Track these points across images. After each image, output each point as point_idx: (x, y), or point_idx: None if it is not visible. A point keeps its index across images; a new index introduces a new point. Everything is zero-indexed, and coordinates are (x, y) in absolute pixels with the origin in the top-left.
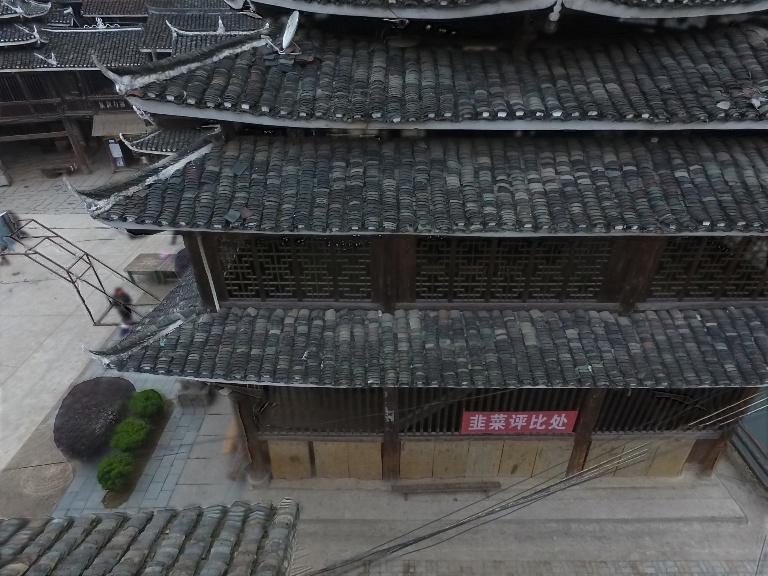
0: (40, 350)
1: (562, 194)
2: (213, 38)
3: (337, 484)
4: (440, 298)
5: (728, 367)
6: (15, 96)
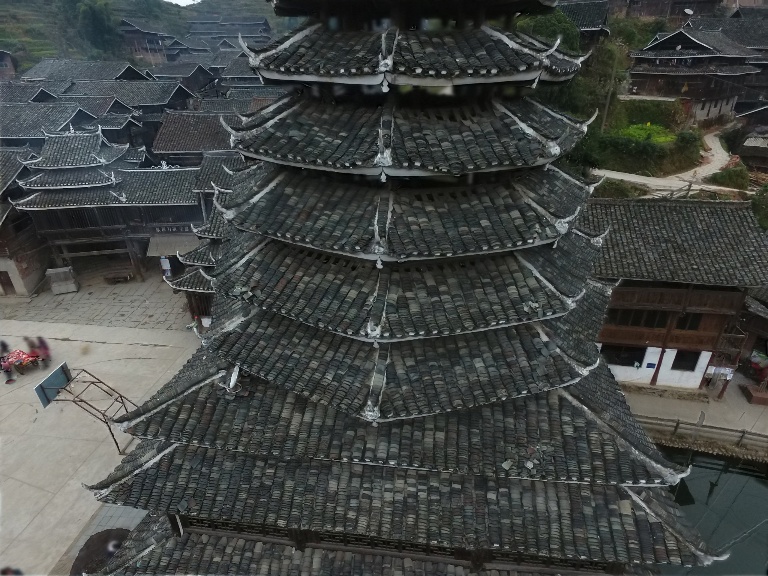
0: (74, 477)
1: (405, 504)
2: None
3: None
4: (338, 542)
5: None
6: (91, 223)
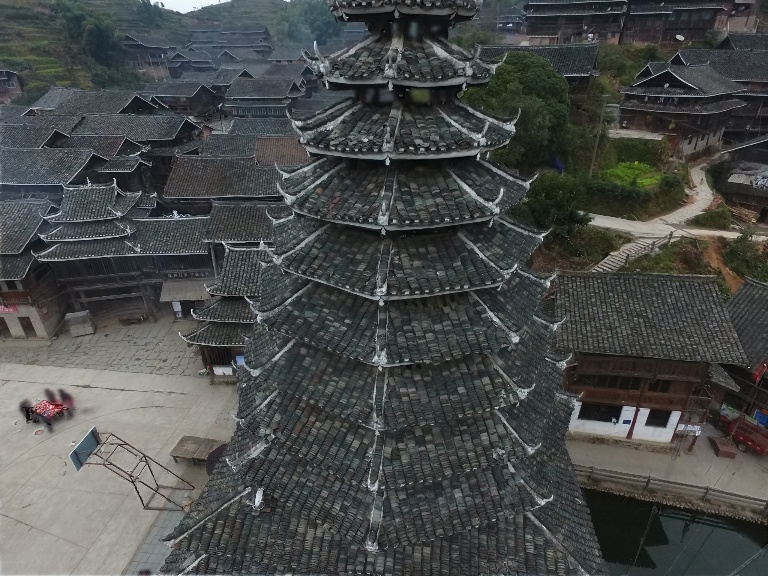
0: (105, 532)
1: None
2: (255, 253)
3: None
4: None
5: None
6: (107, 271)
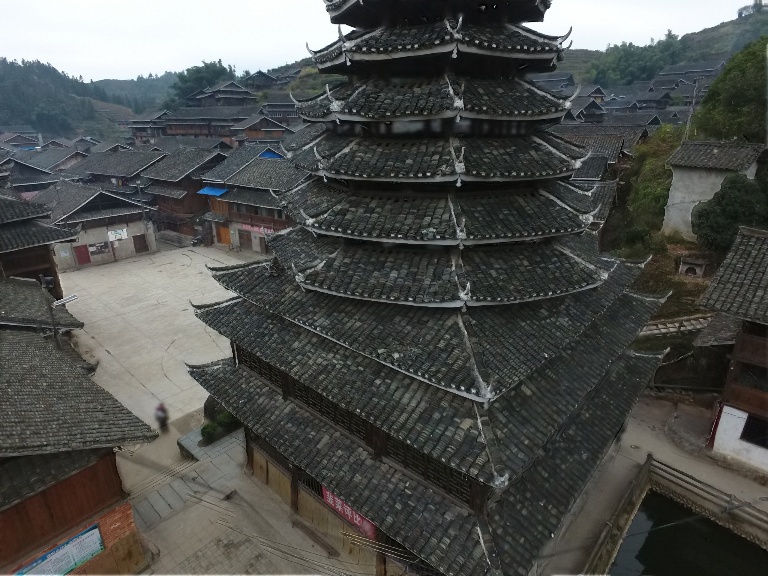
0: None
1: (325, 368)
2: None
3: (274, 496)
4: (305, 403)
5: (388, 518)
6: None
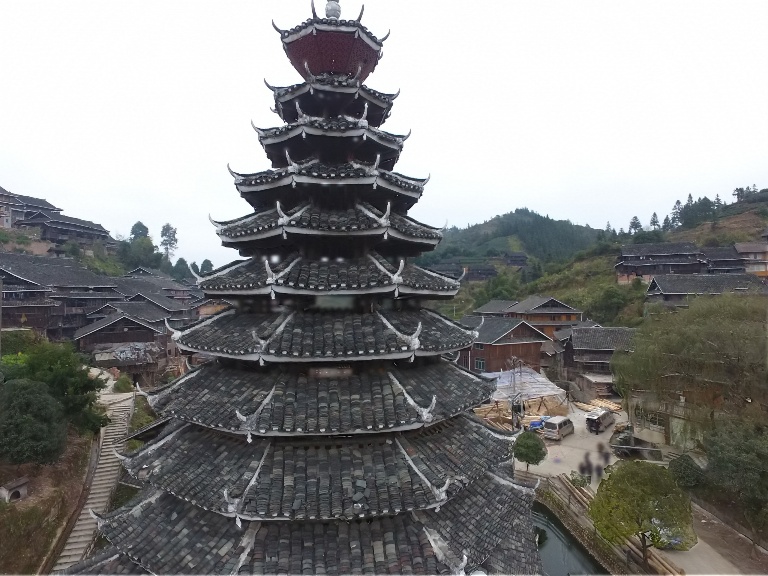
0: None
1: None
2: None
3: None
4: None
5: None
6: None
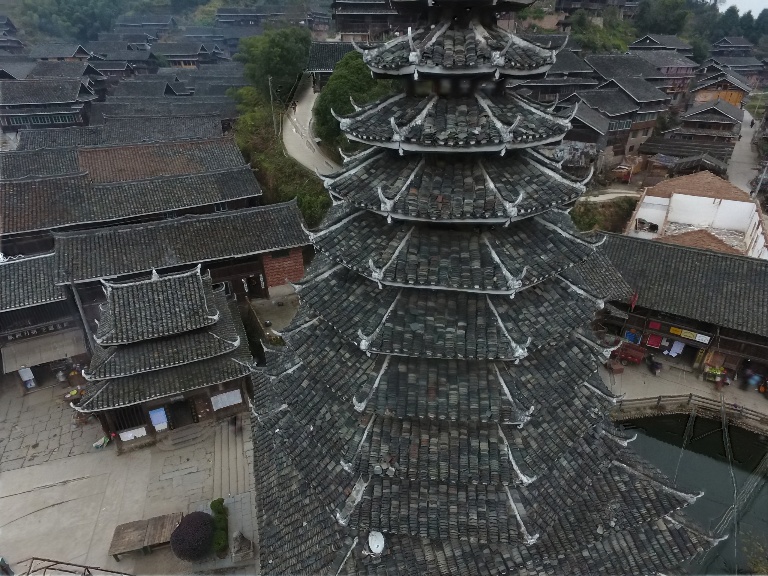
0: None
1: None
2: (149, 286)
3: None
4: None
5: None
6: None
